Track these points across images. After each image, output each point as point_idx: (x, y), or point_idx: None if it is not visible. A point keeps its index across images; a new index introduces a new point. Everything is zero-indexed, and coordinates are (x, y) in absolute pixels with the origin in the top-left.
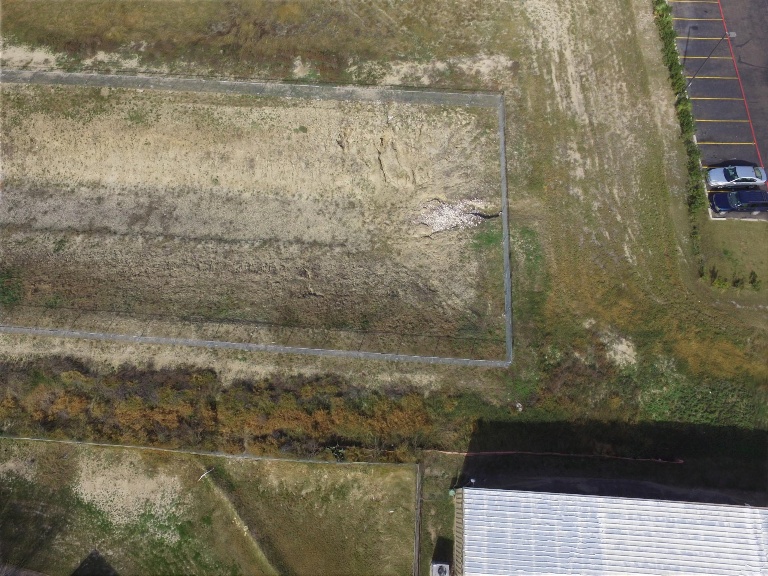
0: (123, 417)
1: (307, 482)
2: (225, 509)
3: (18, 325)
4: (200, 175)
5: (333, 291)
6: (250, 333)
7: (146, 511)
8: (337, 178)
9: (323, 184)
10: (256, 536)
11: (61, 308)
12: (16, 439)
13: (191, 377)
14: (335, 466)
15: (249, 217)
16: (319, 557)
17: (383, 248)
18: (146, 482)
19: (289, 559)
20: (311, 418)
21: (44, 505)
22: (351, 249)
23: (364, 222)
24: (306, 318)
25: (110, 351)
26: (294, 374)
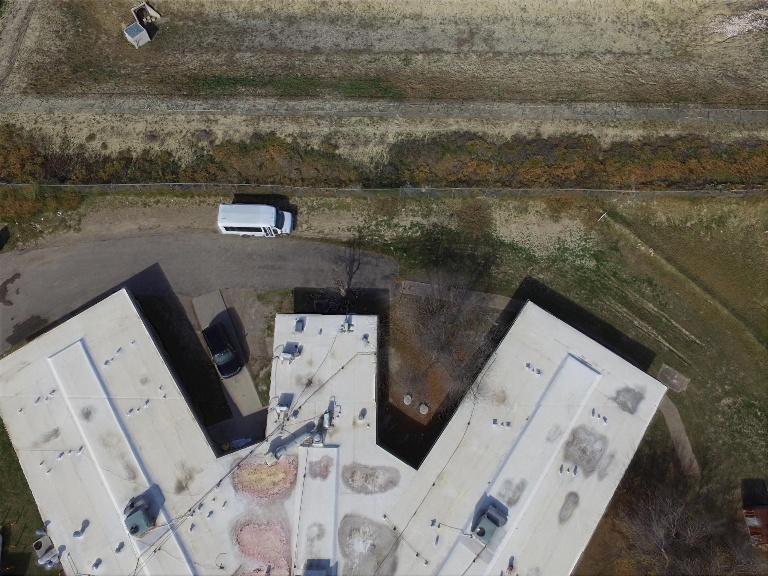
0: (527, 174)
1: (690, 216)
2: (628, 239)
3: (413, 111)
4: (510, 5)
5: (663, 81)
6: (614, 108)
7: (561, 245)
8: (630, 2)
9: (618, 8)
10: (661, 255)
11: (443, 98)
12: (435, 198)
13: (578, 140)
14: (714, 200)
15: (561, 36)
16: (716, 268)
17: (685, 54)
18: (553, 225)
19: (693, 270)
20: (686, 166)
21: (472, 246)
22: (657, 56)
23: (661, 36)
24: (654, 97)
25: (500, 126)
26: (661, 135)
